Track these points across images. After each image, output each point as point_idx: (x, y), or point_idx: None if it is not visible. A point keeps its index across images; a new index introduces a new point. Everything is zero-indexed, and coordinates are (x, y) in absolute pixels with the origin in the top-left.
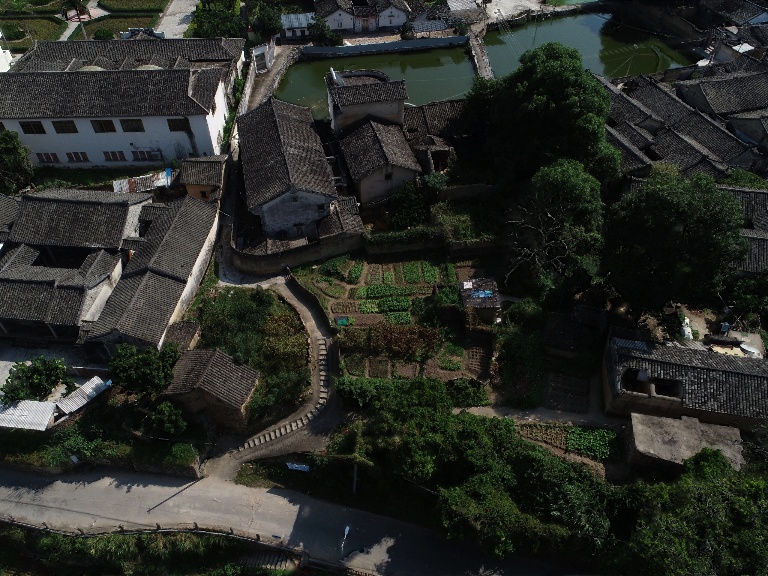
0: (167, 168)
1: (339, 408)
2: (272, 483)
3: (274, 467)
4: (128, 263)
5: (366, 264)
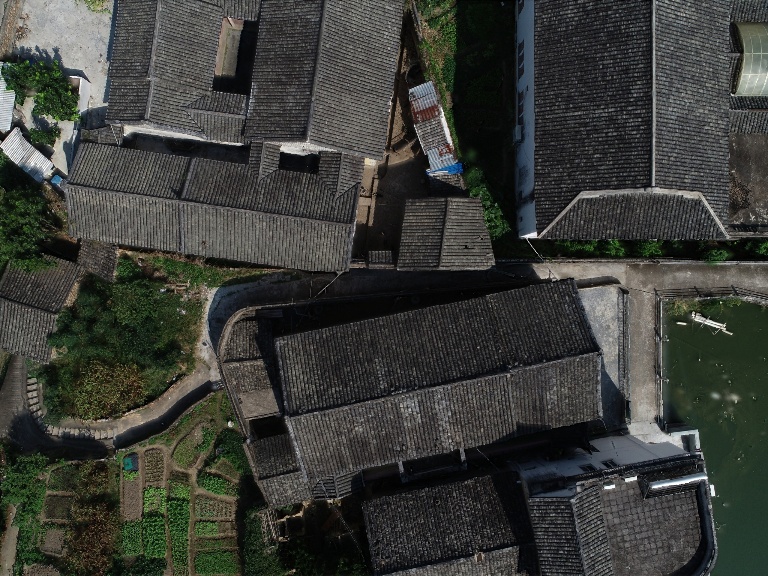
0: (462, 165)
1: (39, 449)
2: (2, 365)
3: (4, 370)
4: (219, 161)
5: (234, 498)
